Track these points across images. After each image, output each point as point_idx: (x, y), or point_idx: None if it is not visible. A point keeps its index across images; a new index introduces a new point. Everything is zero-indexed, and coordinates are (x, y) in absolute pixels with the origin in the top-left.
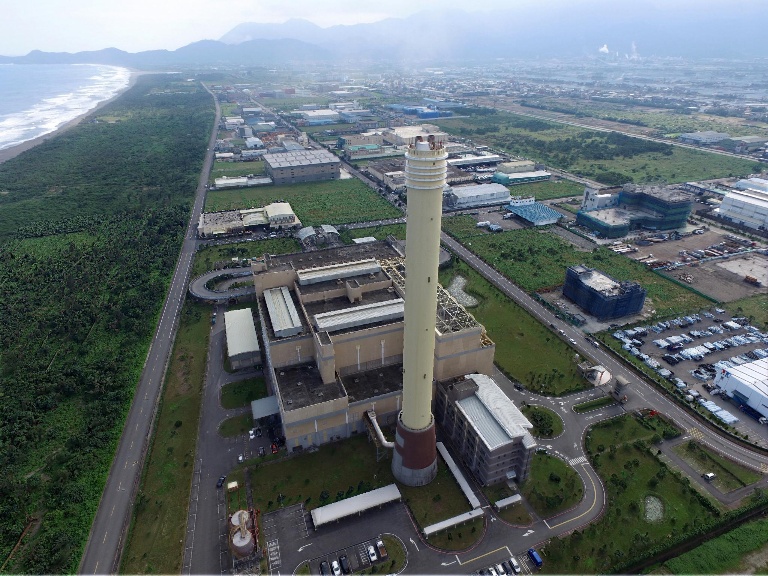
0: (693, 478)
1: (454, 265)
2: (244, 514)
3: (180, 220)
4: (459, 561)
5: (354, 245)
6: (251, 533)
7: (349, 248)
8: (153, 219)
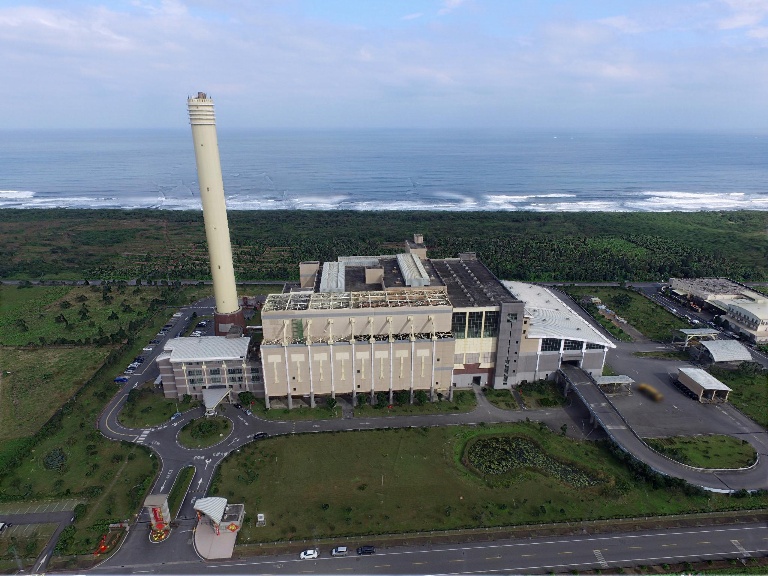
0: (21, 513)
1: None
2: (252, 297)
3: (694, 271)
4: None
5: (507, 290)
6: (240, 300)
7: (498, 288)
8: (687, 262)
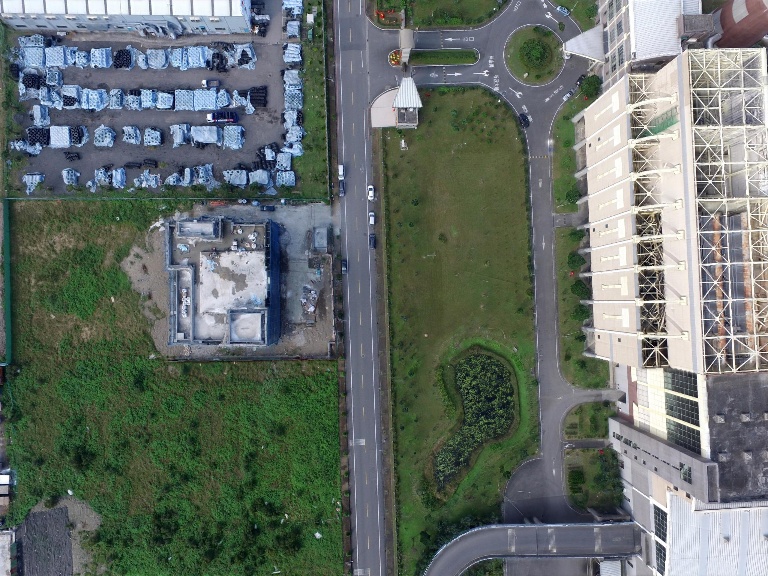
0: None
1: (431, 534)
2: None
3: None
4: None
5: None
6: None
7: None
8: None
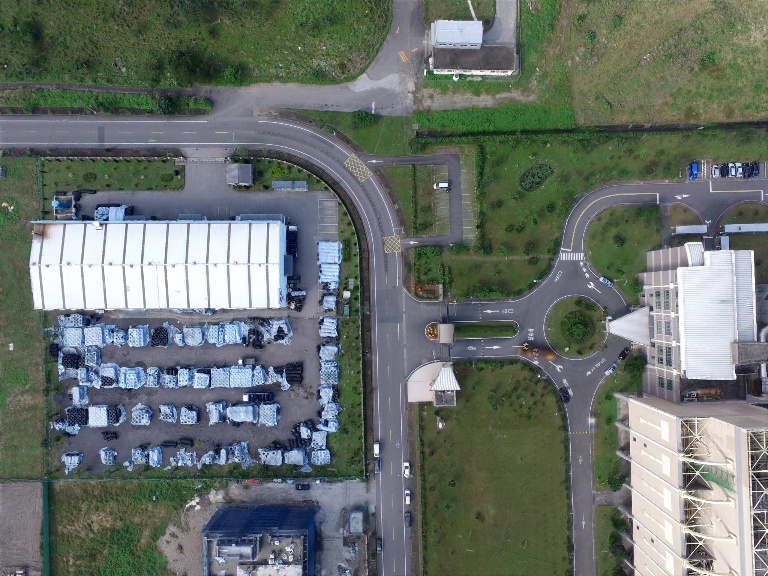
0: (462, 191)
1: None
2: None
3: None
4: (763, 194)
5: None
6: None
7: None
8: None
